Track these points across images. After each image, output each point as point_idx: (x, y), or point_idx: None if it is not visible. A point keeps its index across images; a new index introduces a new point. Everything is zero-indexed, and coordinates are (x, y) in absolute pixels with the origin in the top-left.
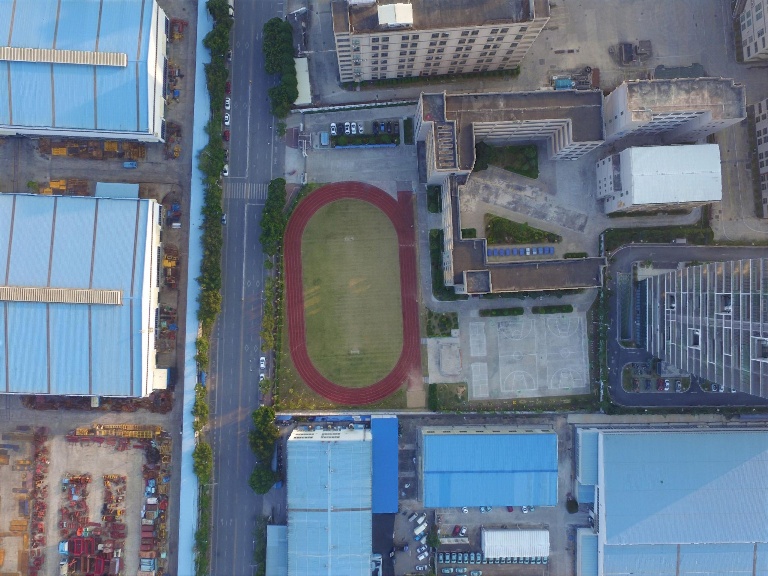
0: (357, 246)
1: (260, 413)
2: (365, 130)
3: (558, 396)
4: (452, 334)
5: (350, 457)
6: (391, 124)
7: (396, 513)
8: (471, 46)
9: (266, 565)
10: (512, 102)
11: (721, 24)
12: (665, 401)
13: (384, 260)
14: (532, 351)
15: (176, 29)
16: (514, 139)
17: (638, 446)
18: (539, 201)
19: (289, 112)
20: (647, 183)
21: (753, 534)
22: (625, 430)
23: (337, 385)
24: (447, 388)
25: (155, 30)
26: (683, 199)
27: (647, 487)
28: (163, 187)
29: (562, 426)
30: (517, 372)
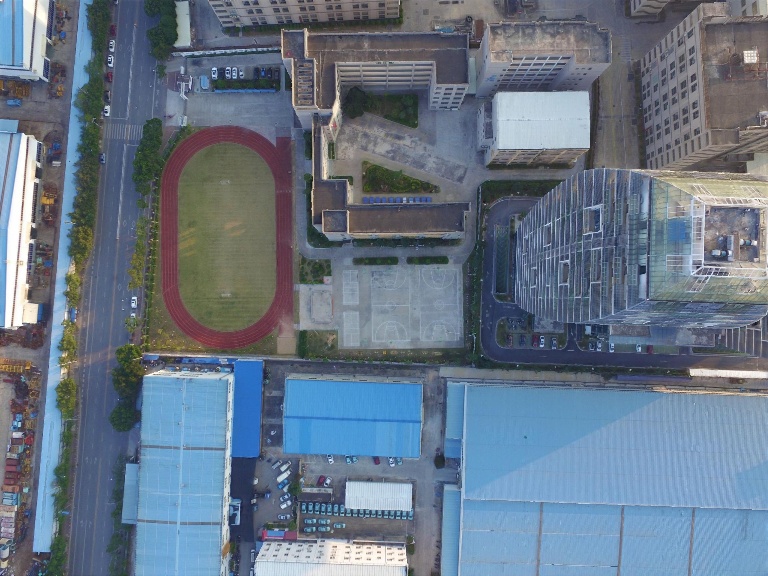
0: (234, 190)
1: (123, 350)
2: (246, 75)
3: (430, 348)
4: (324, 281)
5: (205, 395)
6: (272, 70)
7: (260, 460)
8: None
9: (123, 504)
10: (377, 43)
11: None
12: (540, 358)
13: (260, 205)
14: (405, 302)
15: None
16: (394, 88)
17: (503, 399)
18: (418, 151)
19: (171, 55)
20: (513, 128)
21: (619, 496)
22: (494, 384)
23: (208, 328)
24: (317, 335)
25: None
26: (550, 146)
27: (510, 442)
28: (45, 126)
29: (434, 379)
30: (389, 322)
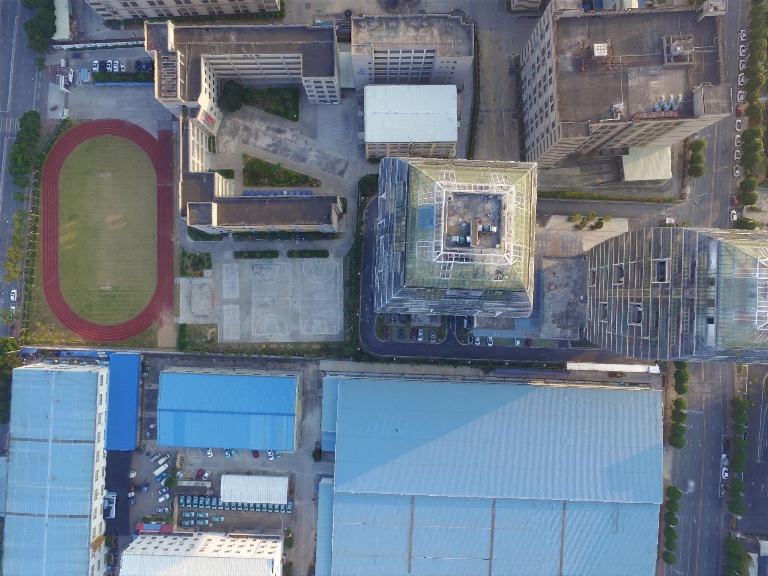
0: (115, 183)
1: None
2: (128, 68)
3: (310, 342)
4: (204, 274)
5: (75, 388)
6: (153, 63)
7: (139, 453)
8: None
9: None
10: (243, 36)
11: None
12: (419, 352)
13: (141, 198)
14: (286, 295)
15: None
16: (275, 81)
17: (375, 392)
18: (299, 144)
19: (52, 48)
20: (380, 121)
21: (489, 489)
22: (370, 378)
23: (88, 321)
24: (197, 329)
25: None
26: (417, 139)
27: (381, 435)
28: None
29: (314, 373)
30: (269, 316)
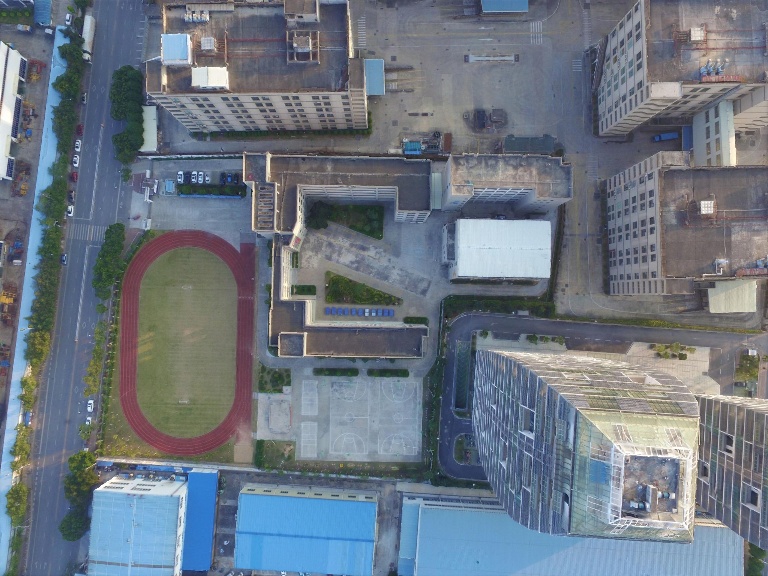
0: (196, 295)
1: (76, 459)
2: (212, 180)
3: (388, 462)
4: (283, 391)
5: (156, 512)
6: (238, 176)
7: (212, 570)
8: (302, 108)
9: None
10: (340, 166)
11: (580, 96)
12: None
13: (222, 311)
14: (364, 414)
15: (34, 70)
16: (360, 199)
17: (457, 523)
18: (382, 262)
19: (137, 158)
20: (473, 256)
21: None
22: (449, 504)
23: (164, 434)
24: (275, 445)
25: (2, 72)
26: (510, 274)
27: (462, 566)
28: (8, 224)
29: (390, 493)
30: (348, 434)
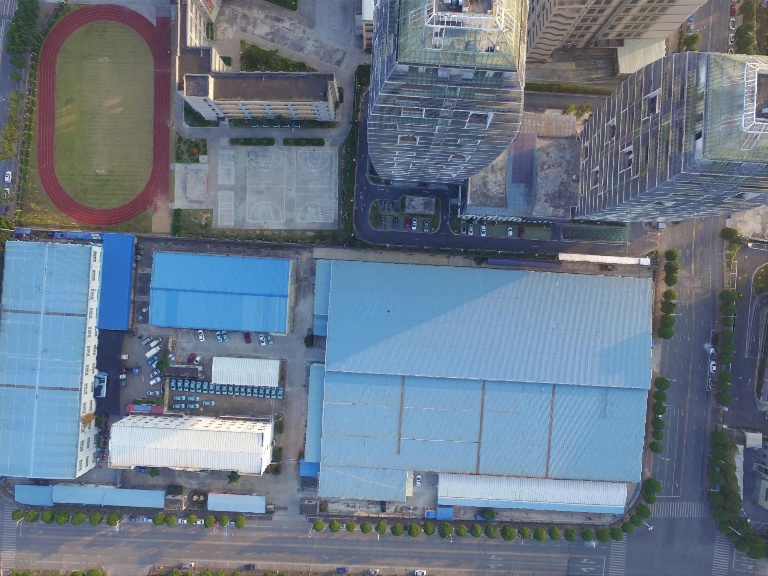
0: (112, 68)
1: None
2: None
3: (304, 229)
4: (200, 160)
5: (68, 261)
6: None
7: (131, 336)
8: None
9: None
10: None
11: None
12: (413, 241)
13: (138, 84)
14: (281, 183)
15: None
16: None
17: (368, 274)
18: (297, 33)
19: None
20: None
21: (479, 370)
22: None
23: (82, 205)
24: (192, 214)
25: None
26: None
27: (373, 315)
28: None
29: (307, 260)
30: (264, 203)
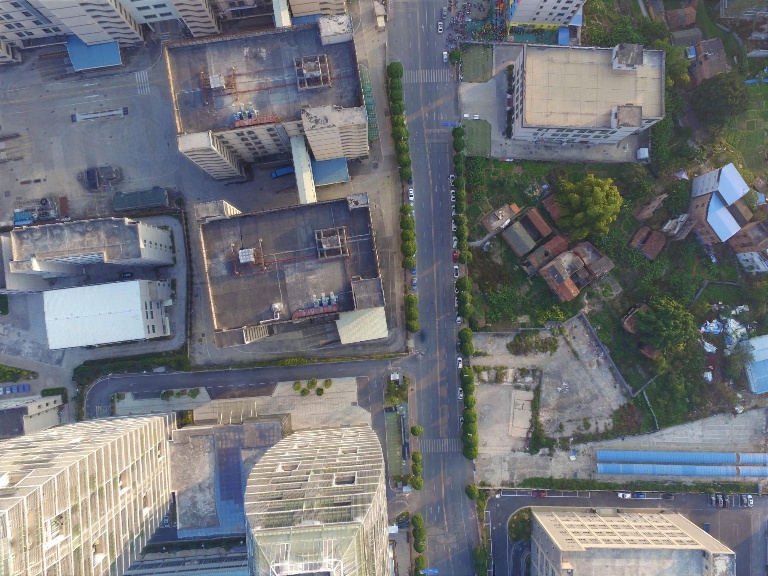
0: None
1: None
2: None
3: None
4: None
5: None
6: None
7: None
8: None
9: None
10: None
11: None
12: (156, 537)
13: None
14: None
15: None
16: None
17: None
18: (12, 337)
19: None
20: (62, 327)
21: None
22: None
23: None
24: None
25: None
26: (103, 341)
27: None
28: None
29: None
30: None
